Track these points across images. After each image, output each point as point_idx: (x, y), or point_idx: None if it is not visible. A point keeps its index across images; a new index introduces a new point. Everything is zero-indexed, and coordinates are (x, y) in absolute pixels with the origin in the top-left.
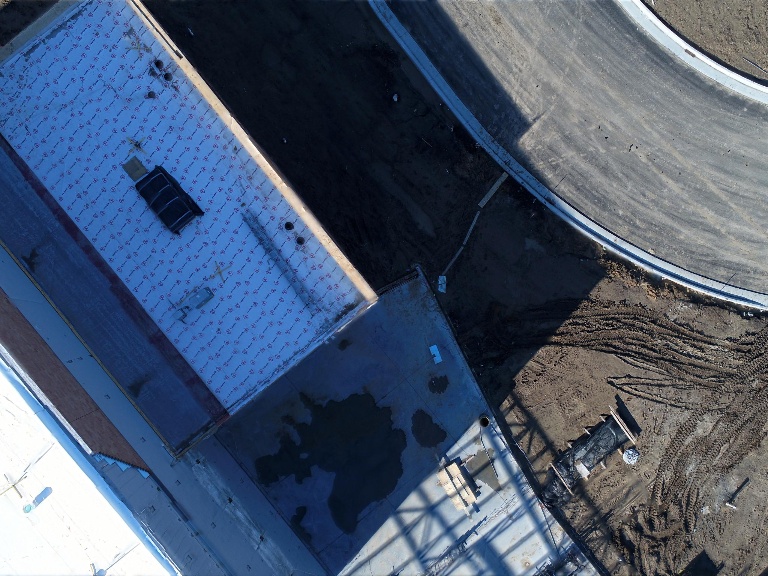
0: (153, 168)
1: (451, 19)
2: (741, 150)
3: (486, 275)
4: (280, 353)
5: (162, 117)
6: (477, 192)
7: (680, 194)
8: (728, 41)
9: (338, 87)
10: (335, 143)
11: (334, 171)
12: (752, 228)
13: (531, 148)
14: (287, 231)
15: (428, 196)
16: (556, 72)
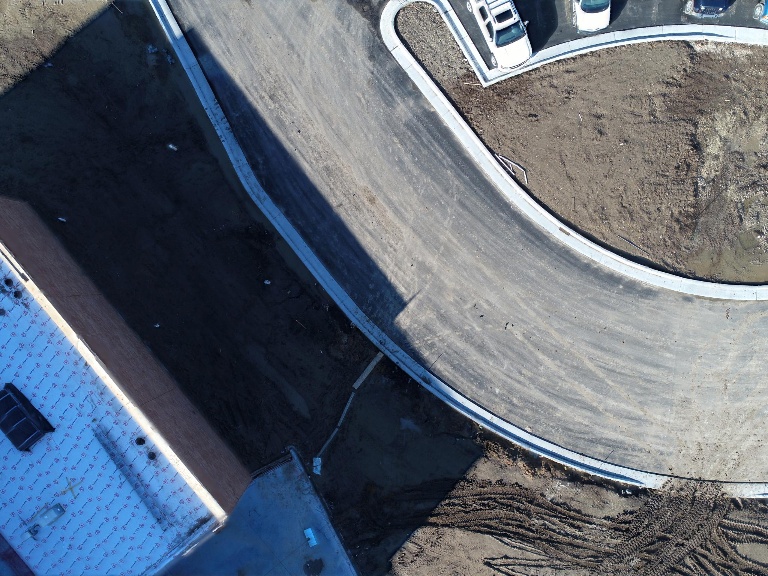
0: (3, 386)
1: (325, 199)
2: (617, 327)
3: (361, 456)
4: (132, 568)
5: (12, 334)
6: (351, 373)
7: (557, 371)
8: (602, 220)
9: (211, 270)
10: (208, 326)
11: (208, 354)
12: (629, 405)
13: (406, 327)
14: (138, 446)
15: (302, 378)
16: (431, 251)
